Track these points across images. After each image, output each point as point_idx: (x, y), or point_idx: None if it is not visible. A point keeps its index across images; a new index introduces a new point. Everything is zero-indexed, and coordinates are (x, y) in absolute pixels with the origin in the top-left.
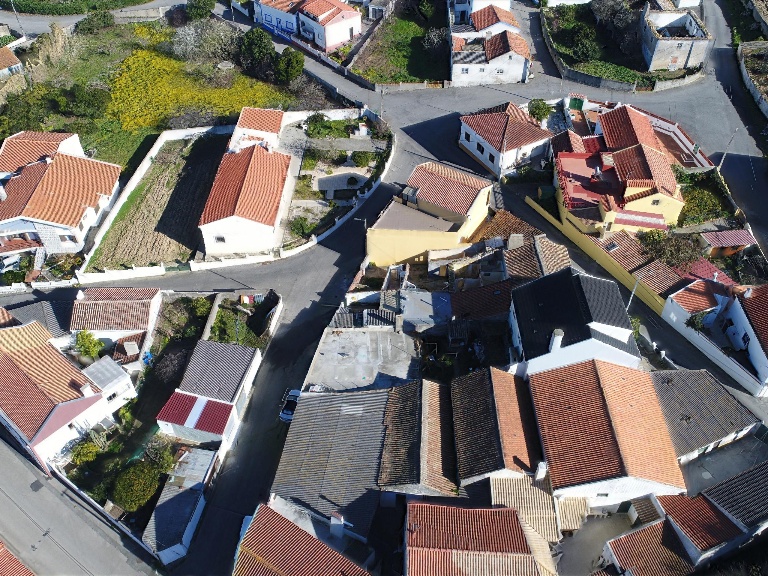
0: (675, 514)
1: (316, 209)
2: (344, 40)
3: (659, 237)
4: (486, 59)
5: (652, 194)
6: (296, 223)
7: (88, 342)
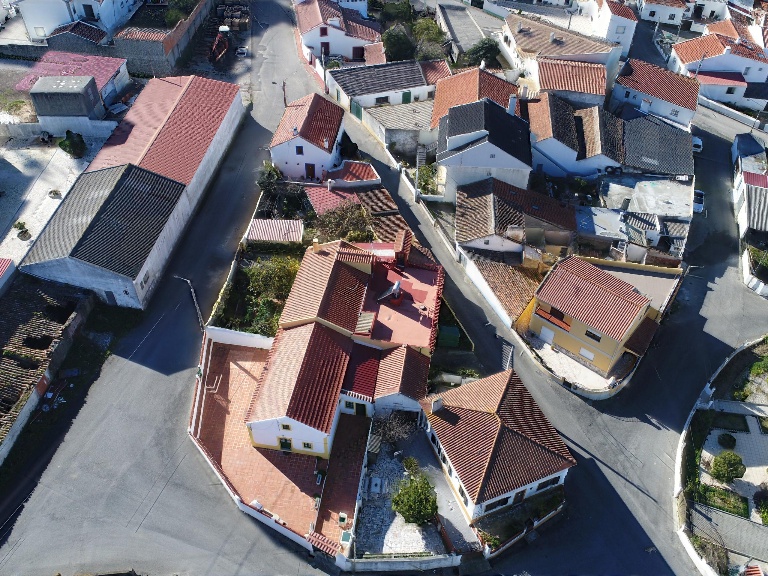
0: None
1: (764, 400)
2: None
3: None
4: None
5: (349, 243)
6: None
7: None
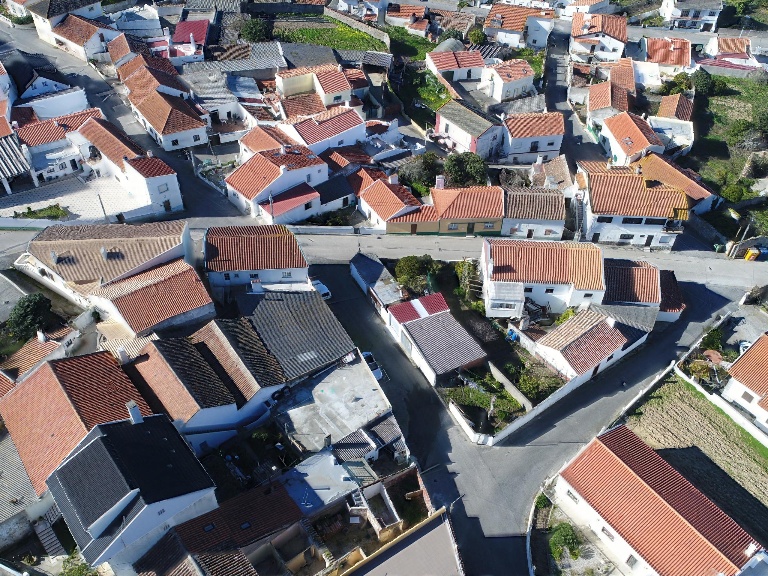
0: (8, 386)
1: None
2: None
3: None
4: None
5: None
6: (566, 525)
7: None
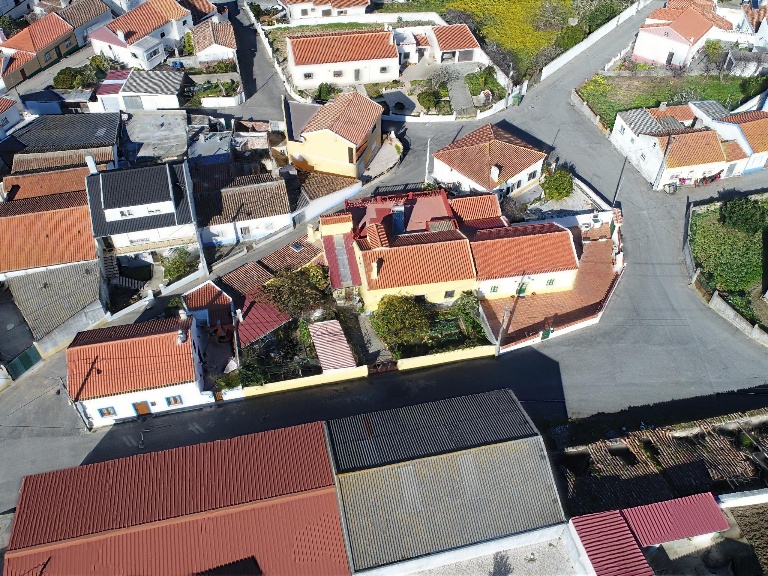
0: None
1: None
2: (658, 60)
3: (312, 276)
4: (645, 132)
5: (360, 248)
6: (321, 84)
7: (187, 40)
